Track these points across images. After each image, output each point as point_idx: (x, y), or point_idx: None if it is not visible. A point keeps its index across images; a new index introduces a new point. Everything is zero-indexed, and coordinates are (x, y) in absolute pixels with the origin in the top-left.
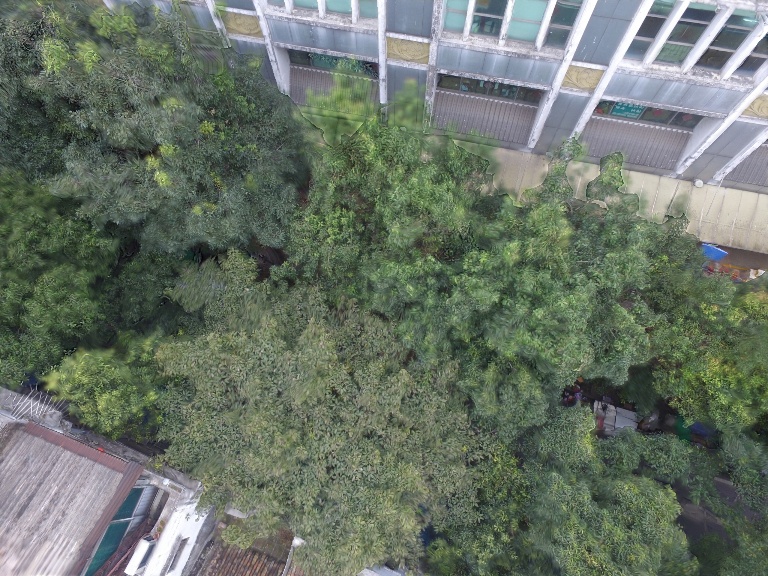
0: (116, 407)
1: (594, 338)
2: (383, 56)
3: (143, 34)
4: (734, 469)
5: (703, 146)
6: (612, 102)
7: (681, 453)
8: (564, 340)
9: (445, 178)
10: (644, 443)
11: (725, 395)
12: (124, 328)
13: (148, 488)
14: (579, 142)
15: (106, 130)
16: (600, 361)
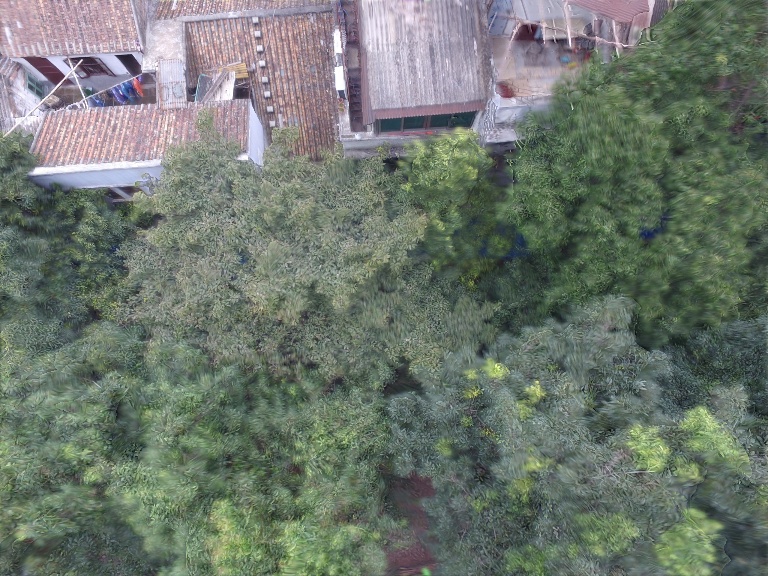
0: None
1: None
2: None
3: (667, 572)
4: None
5: None
6: None
7: None
8: None
9: (192, 571)
10: None
11: None
12: (518, 254)
13: None
14: None
15: None
16: None
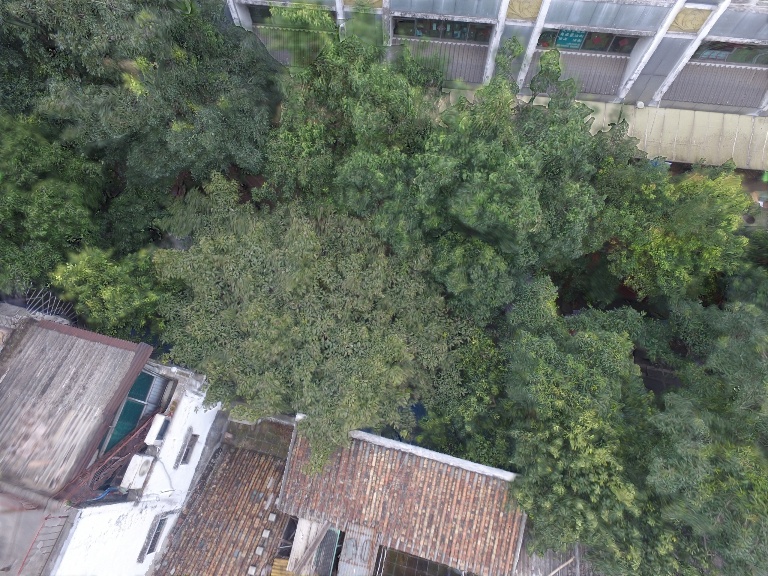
0: (122, 301)
1: (549, 217)
2: (340, 3)
3: None
4: (683, 326)
5: (639, 66)
6: (555, 33)
7: (636, 317)
8: (519, 203)
9: (404, 85)
10: (604, 316)
11: (669, 262)
12: (118, 260)
13: (158, 379)
14: (529, 76)
15: (85, 67)
16: (556, 237)
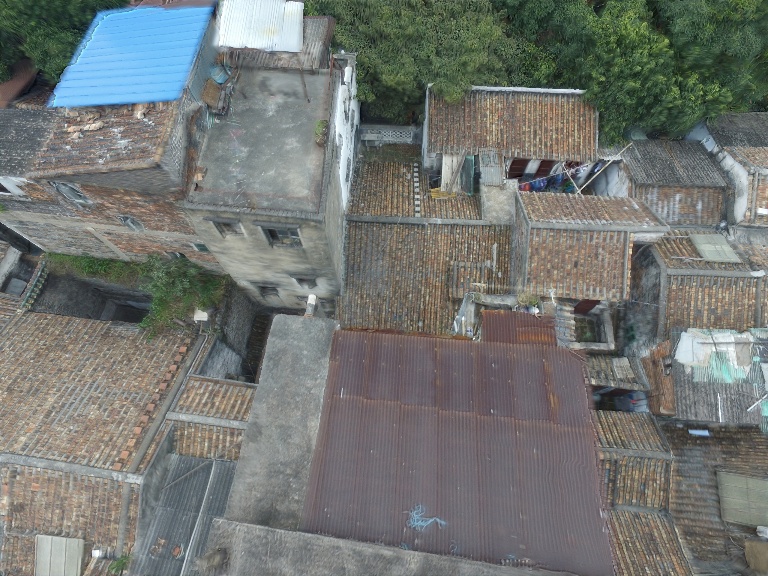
0: None
1: None
2: None
3: None
4: None
5: None
6: None
7: None
8: None
9: None
10: None
11: None
12: None
13: None
14: None
15: None
16: None
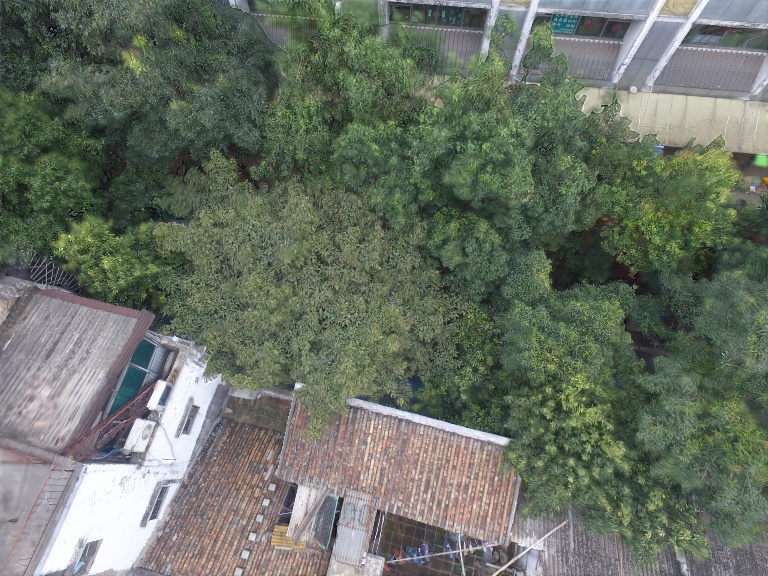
0: (124, 271)
1: (542, 191)
2: None
3: None
4: (673, 299)
5: (632, 51)
6: (548, 19)
7: (628, 291)
8: (512, 173)
9: (399, 62)
10: (597, 291)
11: (660, 237)
12: None
13: (159, 349)
14: None
15: (86, 47)
16: (549, 211)
